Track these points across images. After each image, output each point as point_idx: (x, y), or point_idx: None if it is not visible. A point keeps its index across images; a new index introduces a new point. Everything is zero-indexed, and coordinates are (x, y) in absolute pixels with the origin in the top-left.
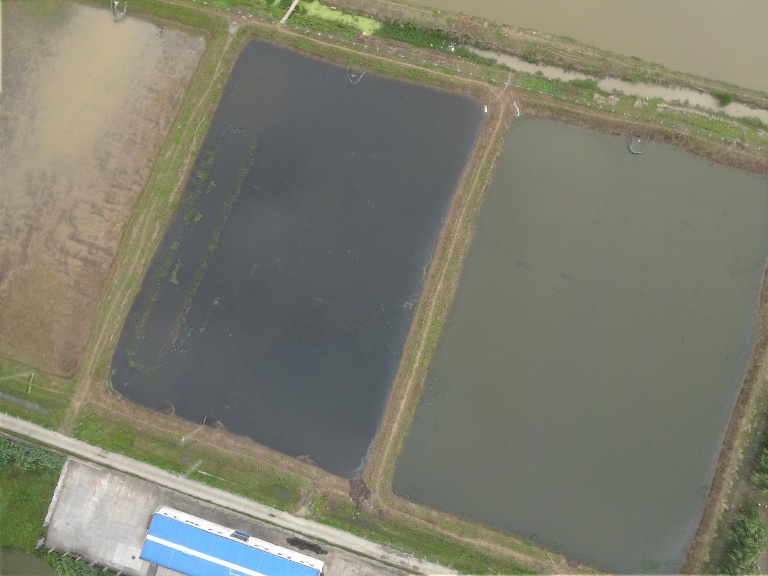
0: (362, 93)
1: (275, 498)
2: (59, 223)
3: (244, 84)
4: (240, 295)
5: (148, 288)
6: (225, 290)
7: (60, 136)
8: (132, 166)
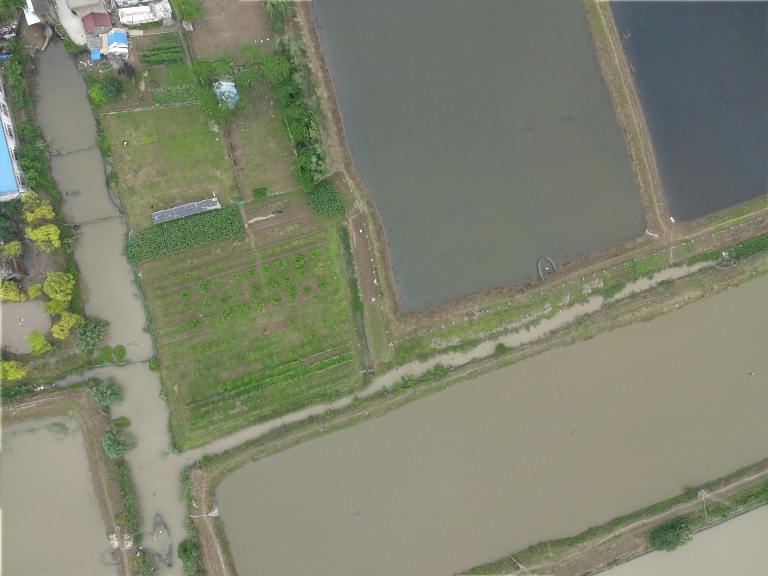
0: (765, 173)
1: None
2: None
3: None
4: None
5: None
6: None
7: None
8: None
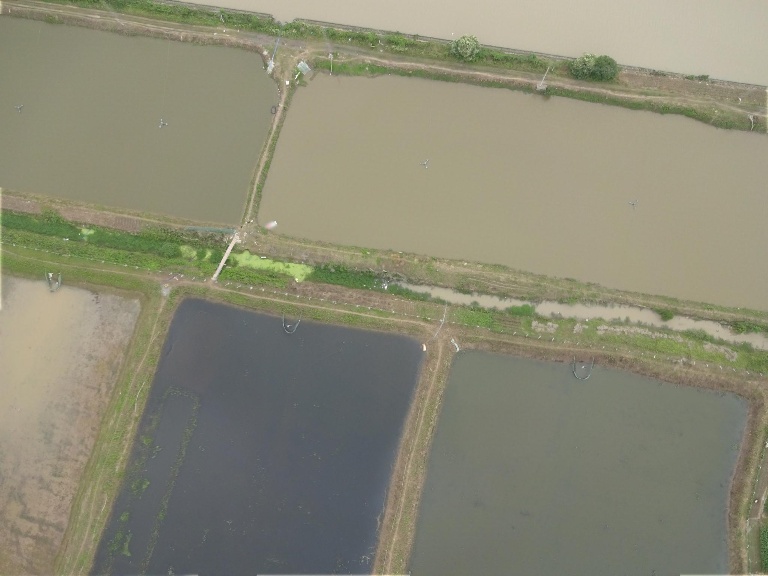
0: (299, 342)
1: None
2: (8, 501)
3: (181, 344)
4: (193, 563)
5: (100, 563)
6: (178, 559)
7: (4, 411)
8: (77, 436)
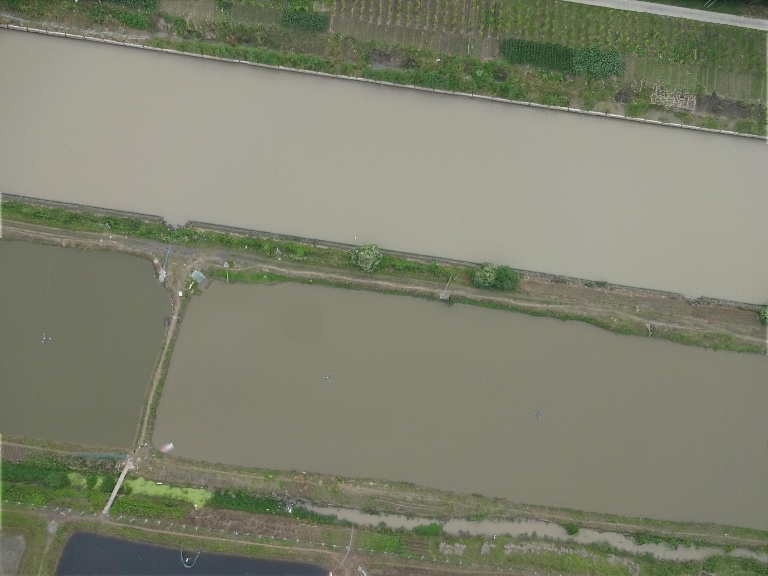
0: None
1: None
2: None
3: None
4: None
5: None
6: None
7: None
8: None
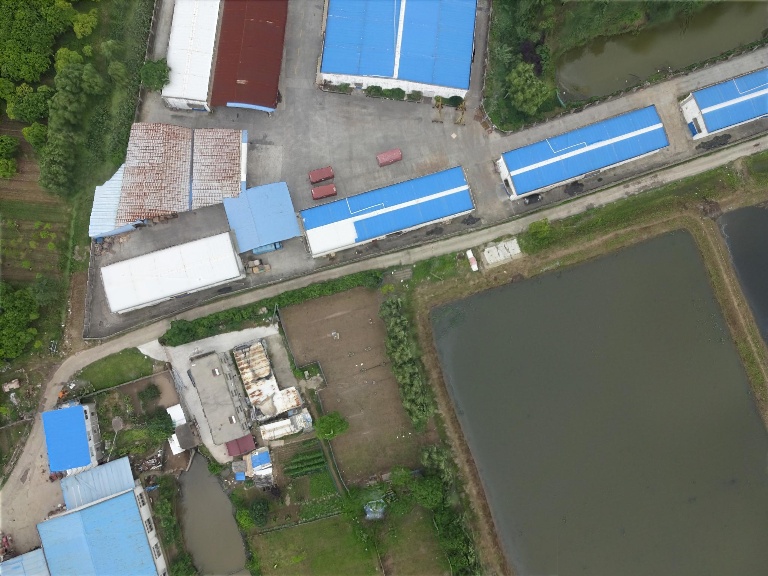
0: None
1: (763, 159)
2: None
3: None
4: None
5: None
6: None
7: None
8: None
